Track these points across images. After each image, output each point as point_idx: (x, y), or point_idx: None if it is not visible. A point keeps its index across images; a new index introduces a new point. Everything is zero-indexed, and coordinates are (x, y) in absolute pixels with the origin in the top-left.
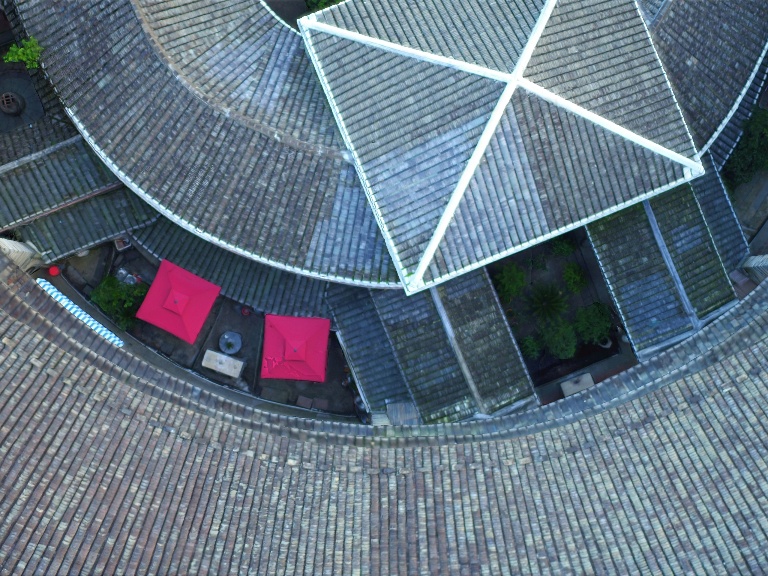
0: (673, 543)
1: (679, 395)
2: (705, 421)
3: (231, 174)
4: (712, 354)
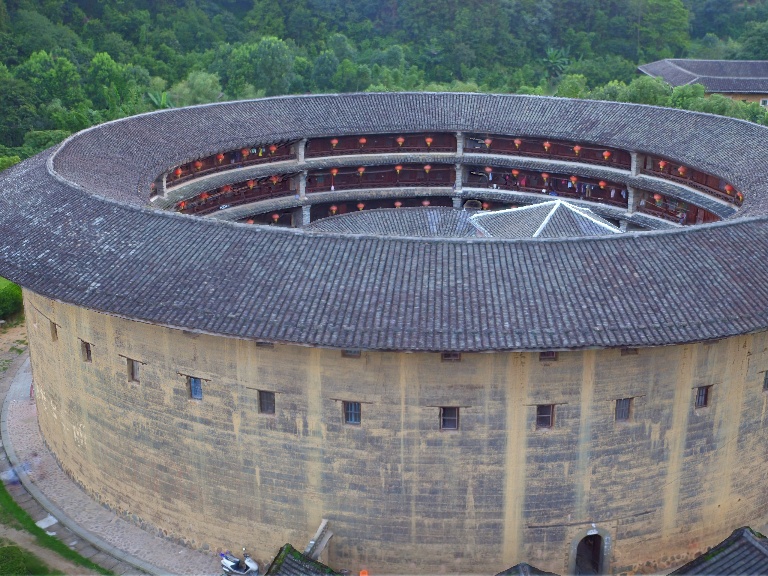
0: (759, 146)
1: None
2: None
3: None
4: None
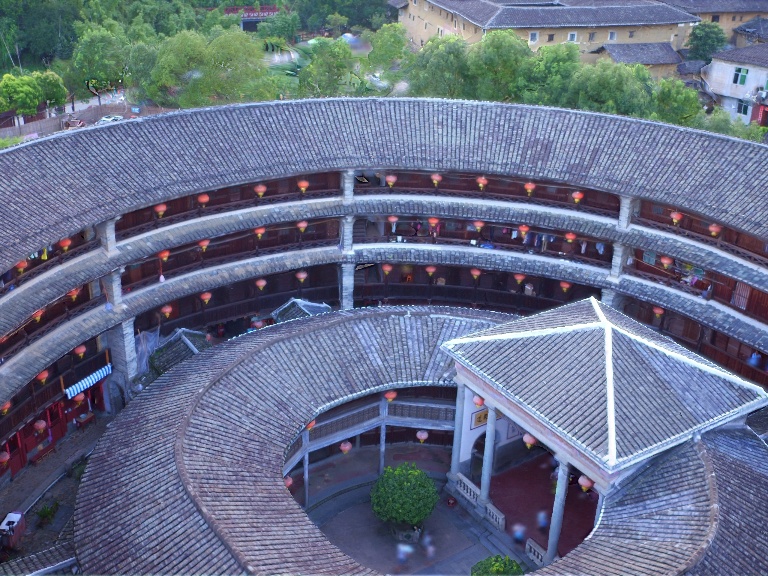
0: None
1: (760, 229)
2: (767, 217)
3: (760, 519)
4: (708, 265)
